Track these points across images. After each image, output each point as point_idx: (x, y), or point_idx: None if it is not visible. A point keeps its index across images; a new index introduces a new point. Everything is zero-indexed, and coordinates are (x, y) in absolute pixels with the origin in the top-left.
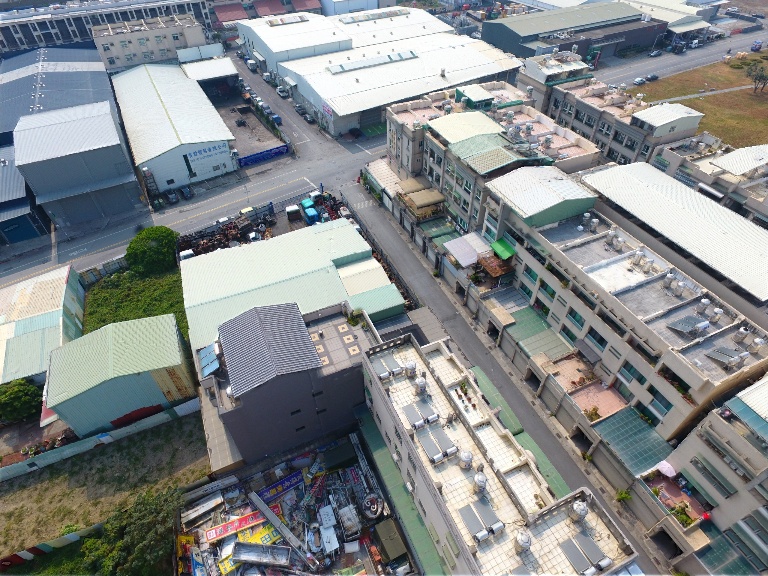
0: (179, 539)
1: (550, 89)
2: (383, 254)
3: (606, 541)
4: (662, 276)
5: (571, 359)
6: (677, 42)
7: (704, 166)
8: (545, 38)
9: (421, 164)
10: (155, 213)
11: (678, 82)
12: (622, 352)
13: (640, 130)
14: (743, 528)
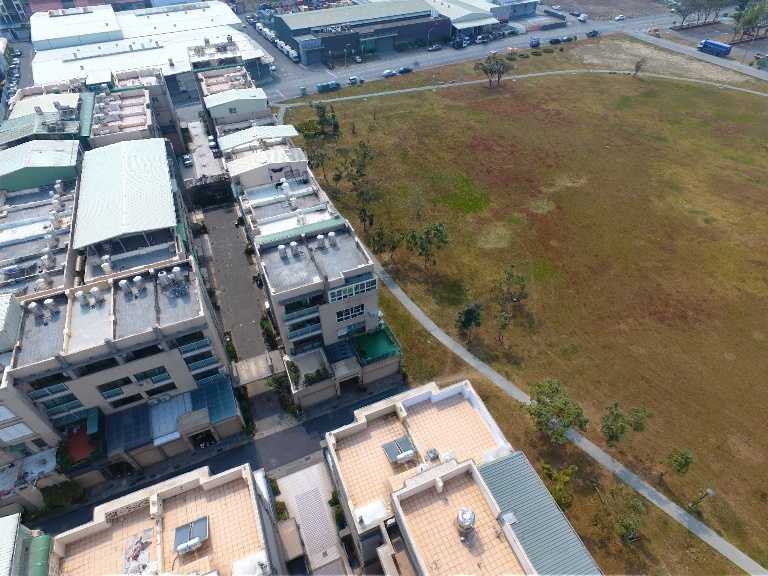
0: None
1: None
2: None
3: None
4: (65, 232)
5: None
6: (462, 37)
7: None
8: (319, 32)
9: None
10: None
11: (427, 75)
12: None
13: None
14: None
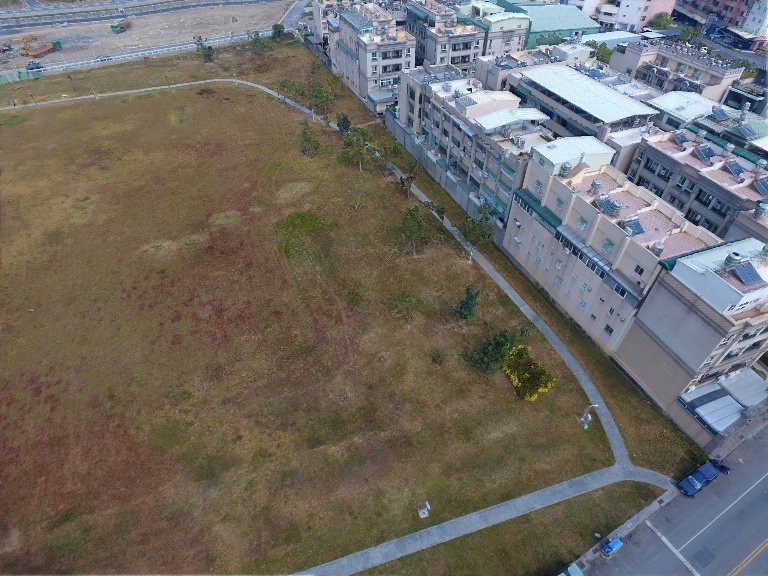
0: None
1: None
2: None
3: None
4: None
5: None
6: None
7: (535, 144)
8: None
9: None
10: None
11: None
12: None
13: None
14: None
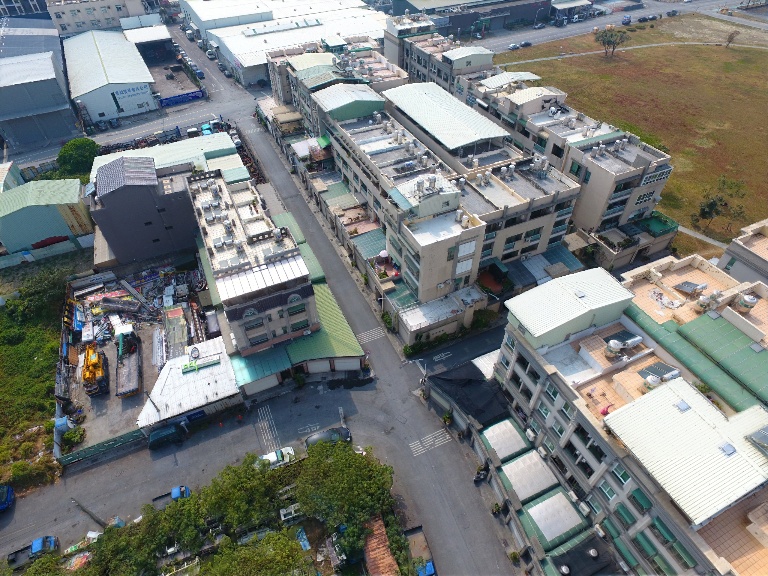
0: (69, 300)
1: (402, 41)
2: (254, 158)
3: None
4: None
5: (357, 208)
6: (560, 17)
7: (486, 89)
8: (441, 12)
9: (291, 95)
10: (87, 137)
11: (547, 48)
12: (371, 190)
13: (447, 65)
14: (408, 272)
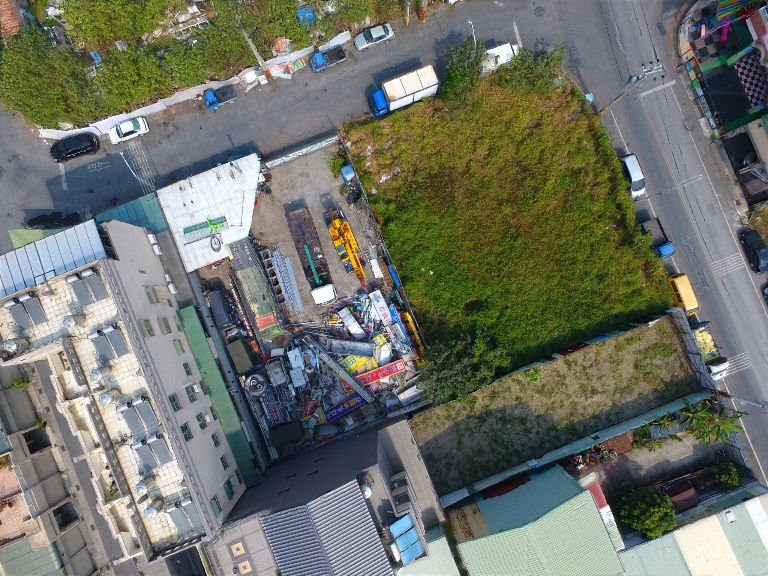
0: None
1: None
2: None
3: (6, 322)
4: None
5: (3, 540)
6: None
7: None
8: None
9: None
10: None
11: None
12: None
13: None
14: None
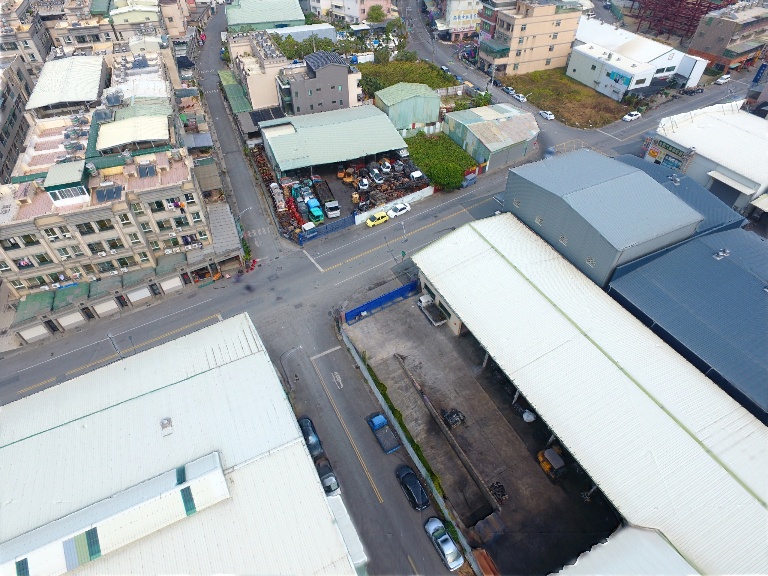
0: None
1: None
2: None
3: None
4: None
5: None
6: None
7: None
8: None
9: None
10: None
11: None
12: None
13: None
14: None
